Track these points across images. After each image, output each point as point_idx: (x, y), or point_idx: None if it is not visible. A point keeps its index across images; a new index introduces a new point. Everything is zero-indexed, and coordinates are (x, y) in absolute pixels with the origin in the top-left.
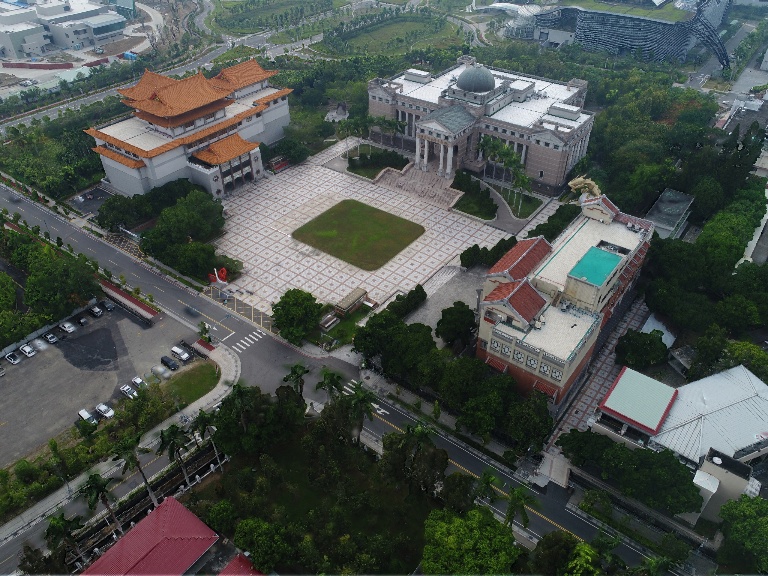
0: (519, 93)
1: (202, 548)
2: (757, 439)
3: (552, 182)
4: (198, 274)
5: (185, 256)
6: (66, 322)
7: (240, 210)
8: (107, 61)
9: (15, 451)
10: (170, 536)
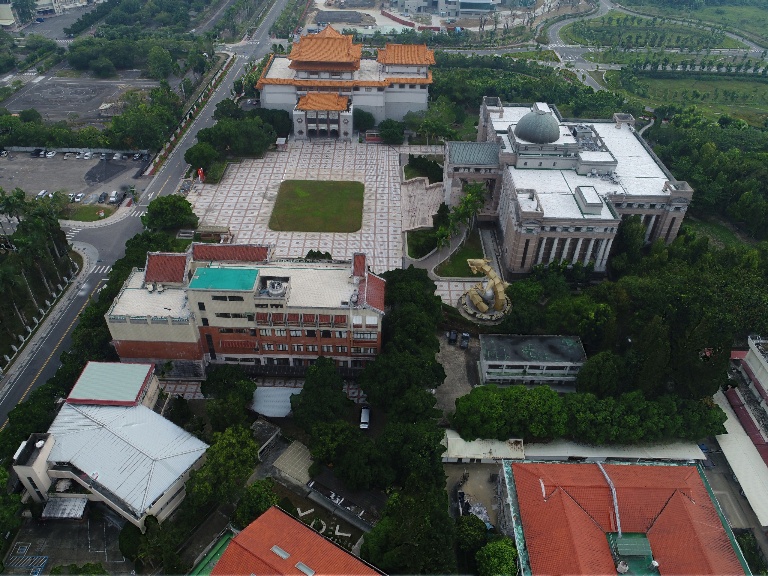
0: (580, 163)
1: None
2: (92, 474)
3: (508, 263)
4: (191, 166)
5: (189, 149)
6: (119, 153)
7: (295, 151)
8: (439, 30)
9: (10, 190)
10: None
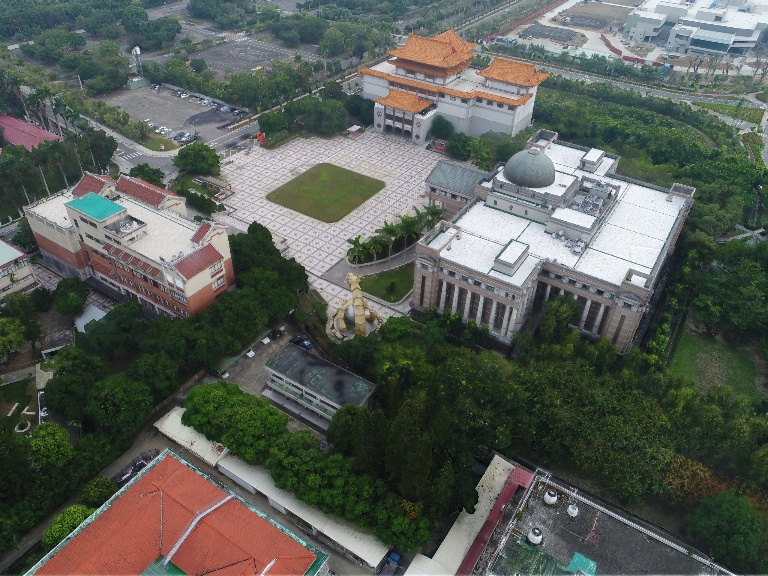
0: None
1: (29, 148)
2: None
3: None
4: None
5: None
6: None
7: (362, 141)
8: None
9: None
10: (38, 139)
